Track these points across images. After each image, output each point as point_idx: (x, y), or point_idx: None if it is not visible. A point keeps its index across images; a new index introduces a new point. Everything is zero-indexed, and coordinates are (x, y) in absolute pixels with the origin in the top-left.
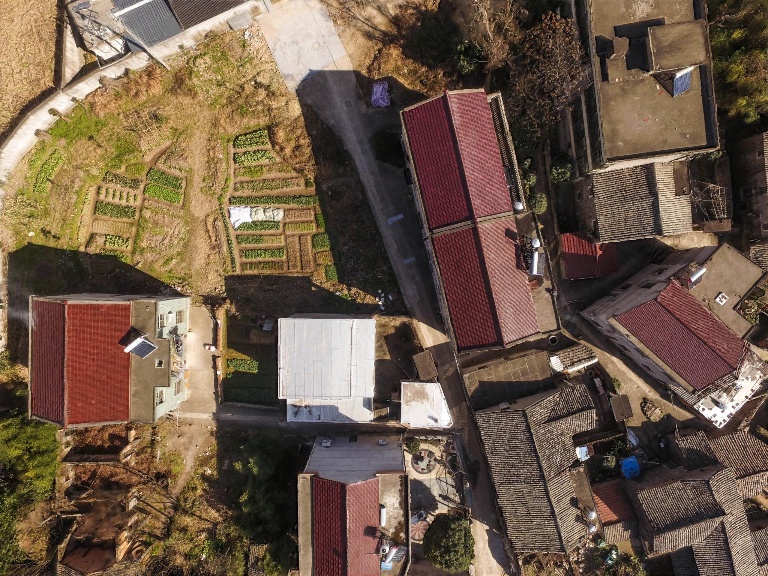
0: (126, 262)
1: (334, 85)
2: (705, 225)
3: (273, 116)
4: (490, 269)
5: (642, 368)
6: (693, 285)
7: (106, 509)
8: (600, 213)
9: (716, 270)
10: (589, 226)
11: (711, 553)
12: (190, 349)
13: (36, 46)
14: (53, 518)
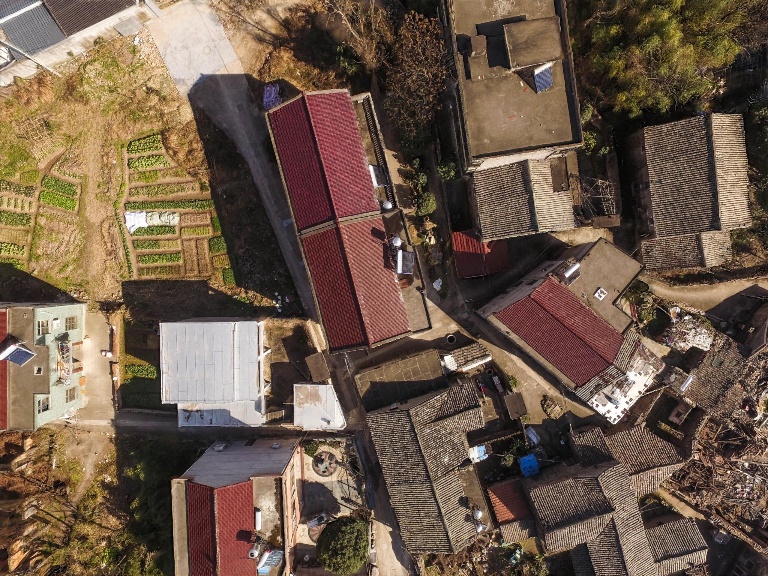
0: (22, 270)
1: (226, 89)
2: (594, 221)
3: (166, 121)
4: (354, 269)
5: (541, 365)
6: (569, 281)
7: (5, 519)
8: (482, 211)
9: (594, 265)
10: (477, 224)
11: (604, 550)
12: (87, 356)
13: None
14: None
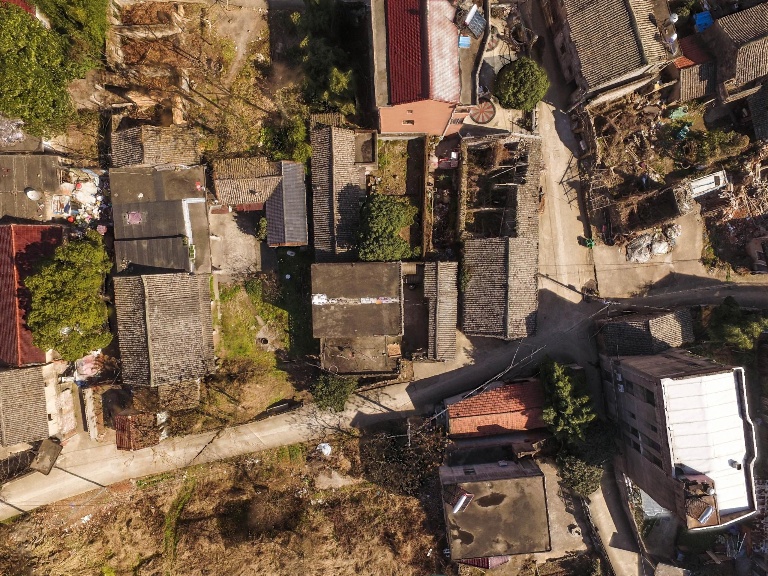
0: None
1: None
2: None
3: None
4: None
5: None
6: None
7: None
8: None
9: None
10: None
11: None
12: None
13: None
14: (103, 109)
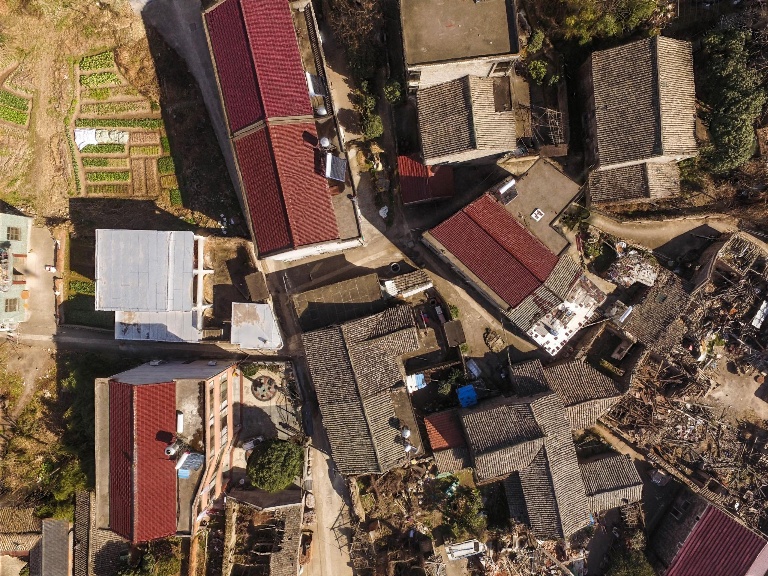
0: None
1: (179, 8)
2: (541, 150)
3: (118, 38)
4: (282, 170)
5: (485, 298)
6: (505, 199)
7: None
8: (424, 130)
9: (532, 186)
10: None
11: (535, 479)
12: (31, 270)
13: None
14: None
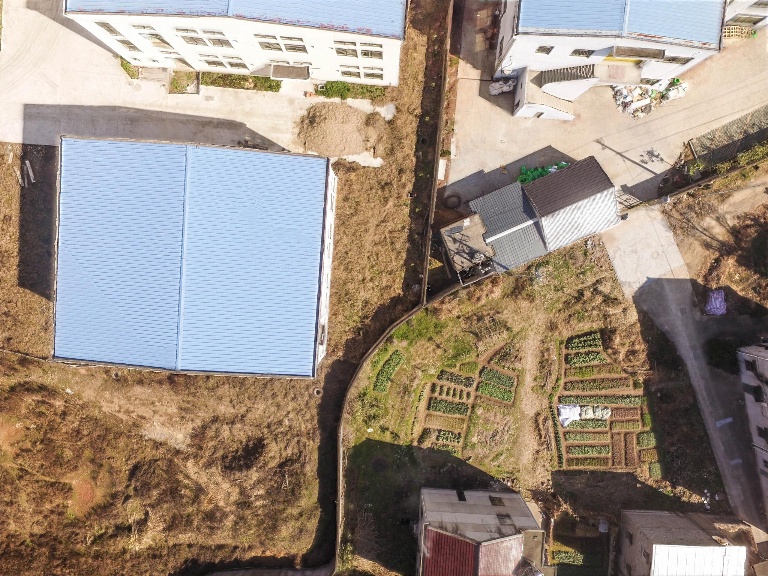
0: (457, 456)
1: (670, 293)
2: None
3: (608, 321)
4: None
5: None
6: None
7: None
8: None
9: None
10: None
11: None
12: None
13: (388, 255)
14: None
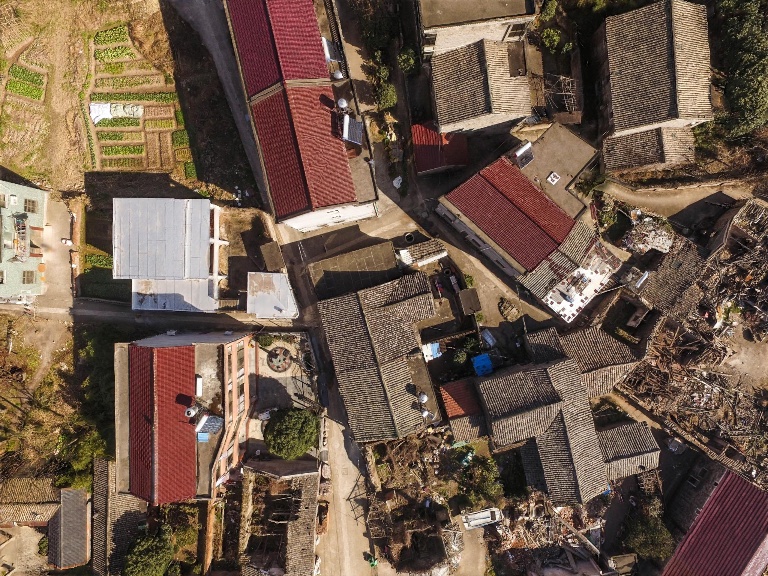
0: None
1: None
2: (555, 117)
3: (132, 12)
4: (300, 132)
5: (499, 267)
6: (521, 162)
7: None
8: (438, 96)
9: (548, 149)
10: (436, 116)
11: (553, 445)
12: (47, 243)
13: None
14: None
